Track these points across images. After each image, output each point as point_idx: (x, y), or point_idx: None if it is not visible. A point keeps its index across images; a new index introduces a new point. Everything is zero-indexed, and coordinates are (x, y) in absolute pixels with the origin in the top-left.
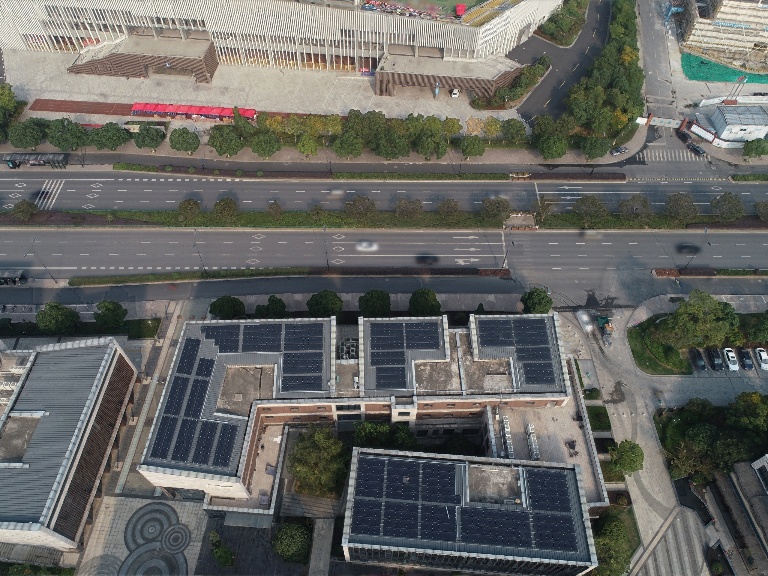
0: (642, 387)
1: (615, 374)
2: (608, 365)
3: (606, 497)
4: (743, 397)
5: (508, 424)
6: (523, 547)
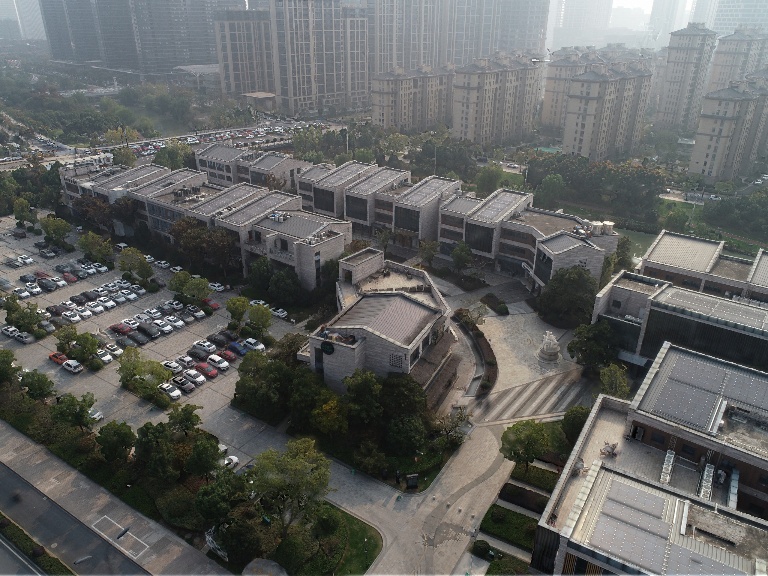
0: (404, 523)
1: (425, 556)
2: (423, 572)
3: (600, 398)
4: (332, 421)
5: (703, 495)
6: (743, 376)
